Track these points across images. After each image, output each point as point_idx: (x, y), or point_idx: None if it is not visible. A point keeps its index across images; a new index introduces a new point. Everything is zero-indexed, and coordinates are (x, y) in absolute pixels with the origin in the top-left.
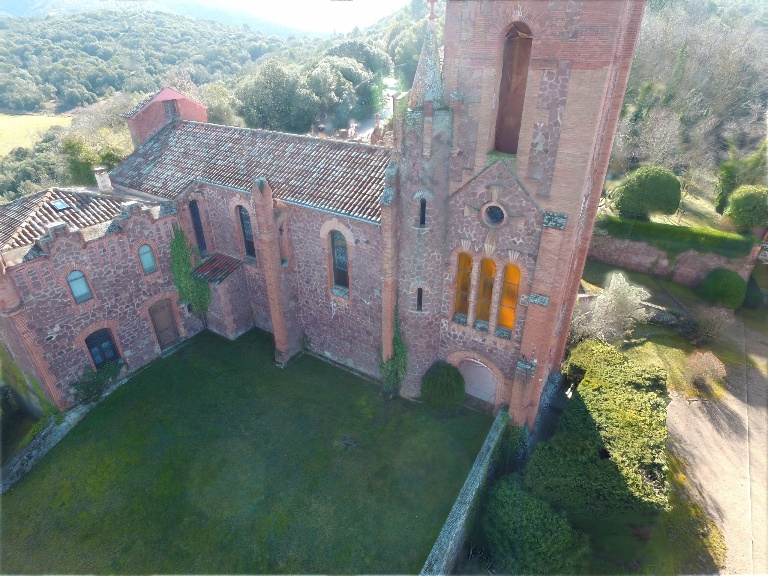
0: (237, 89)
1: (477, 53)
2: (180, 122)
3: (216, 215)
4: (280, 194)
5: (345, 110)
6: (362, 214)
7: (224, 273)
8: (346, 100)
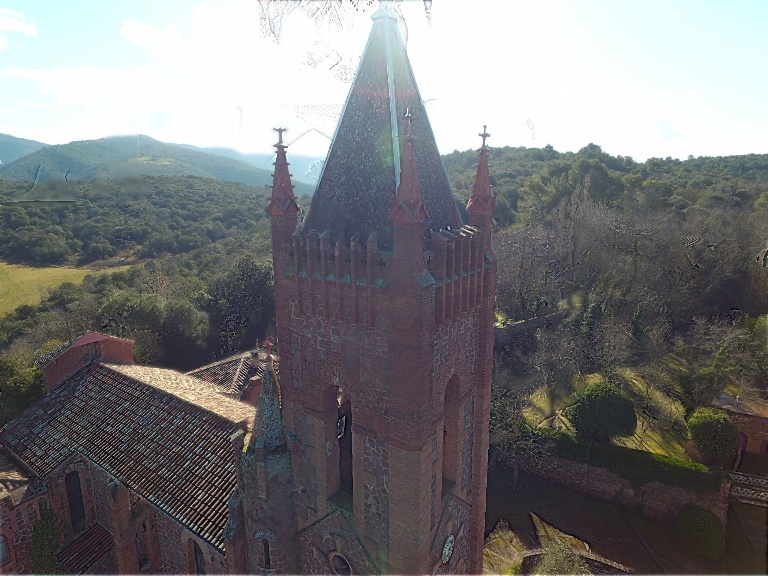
0: (212, 280)
1: (307, 402)
2: (96, 365)
3: (97, 485)
4: (144, 489)
5: None
6: (212, 537)
7: (91, 558)
8: None
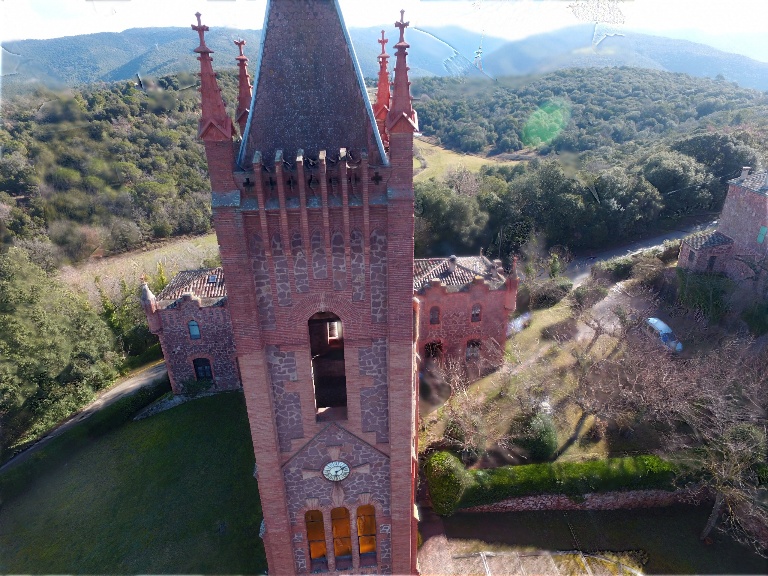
0: None
1: None
2: None
3: None
4: None
5: (628, 219)
6: None
7: None
8: (633, 209)
